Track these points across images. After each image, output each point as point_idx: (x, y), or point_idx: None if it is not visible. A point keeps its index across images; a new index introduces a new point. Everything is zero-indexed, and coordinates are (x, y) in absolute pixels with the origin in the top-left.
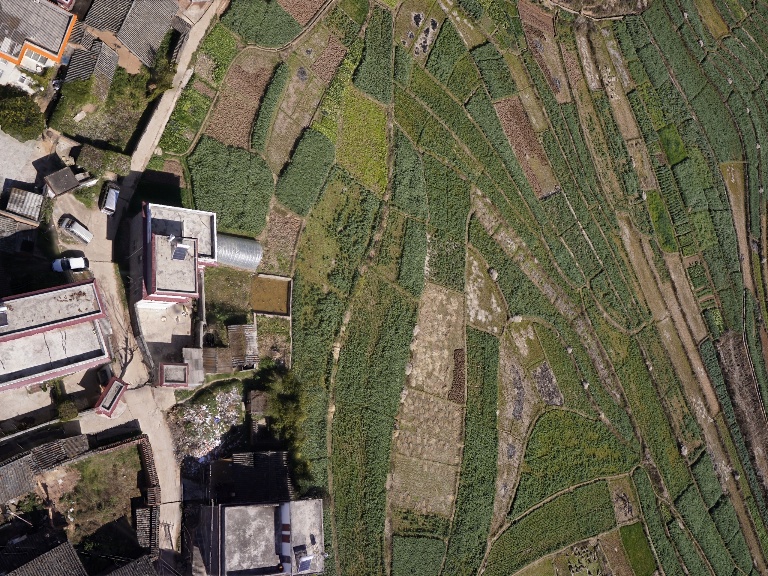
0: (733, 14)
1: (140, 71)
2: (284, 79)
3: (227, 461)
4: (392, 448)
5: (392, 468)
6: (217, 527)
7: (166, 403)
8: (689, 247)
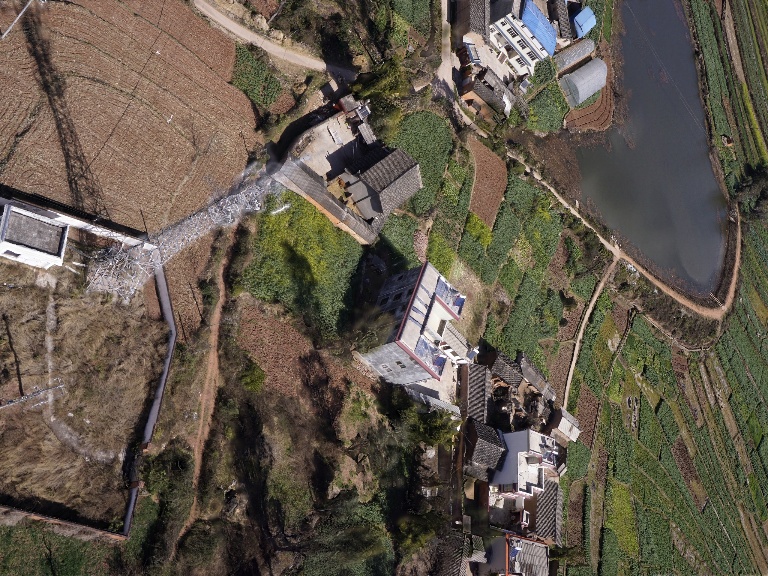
0: None
1: (549, 545)
2: None
3: None
4: None
5: None
6: None
7: None
8: None
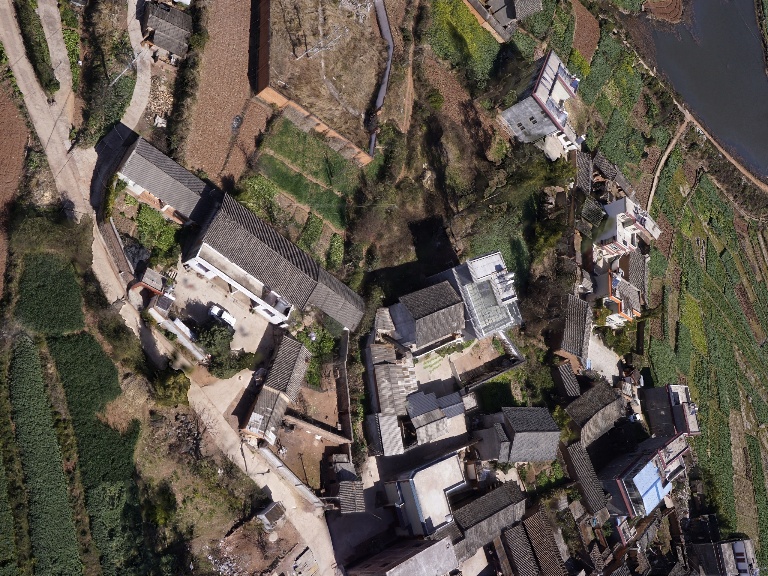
0: None
1: None
2: (668, 295)
3: (698, 520)
4: (735, 509)
5: (737, 521)
6: (716, 555)
7: None
8: None
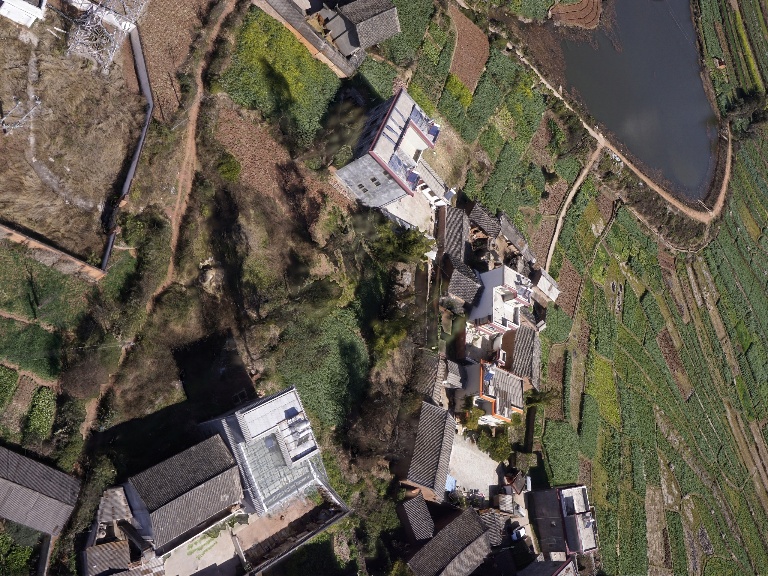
0: (761, 217)
1: (527, 391)
2: (571, 363)
3: None
4: None
5: None
6: None
7: None
8: (761, 414)
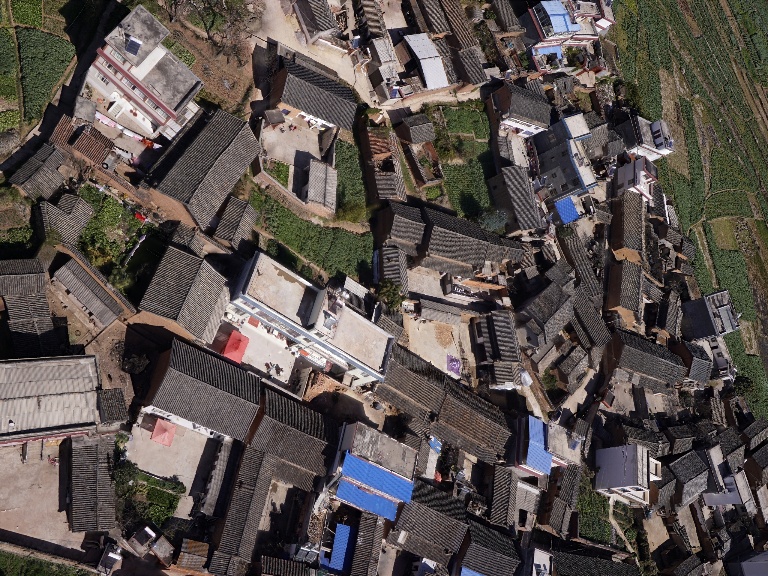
0: None
1: None
2: None
3: (620, 110)
4: None
5: None
6: (633, 126)
7: (593, 81)
8: (765, 82)
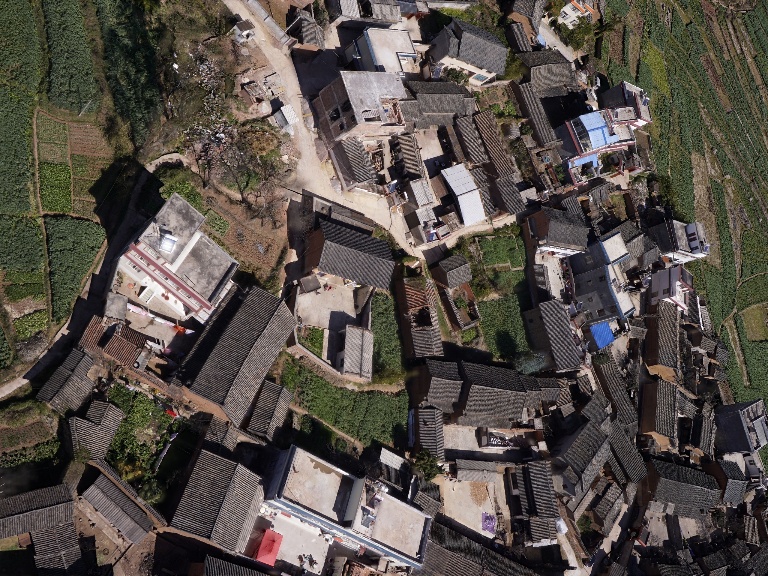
0: None
1: (595, 22)
2: (629, 33)
3: (654, 209)
4: None
5: None
6: (668, 230)
7: (627, 180)
8: None
